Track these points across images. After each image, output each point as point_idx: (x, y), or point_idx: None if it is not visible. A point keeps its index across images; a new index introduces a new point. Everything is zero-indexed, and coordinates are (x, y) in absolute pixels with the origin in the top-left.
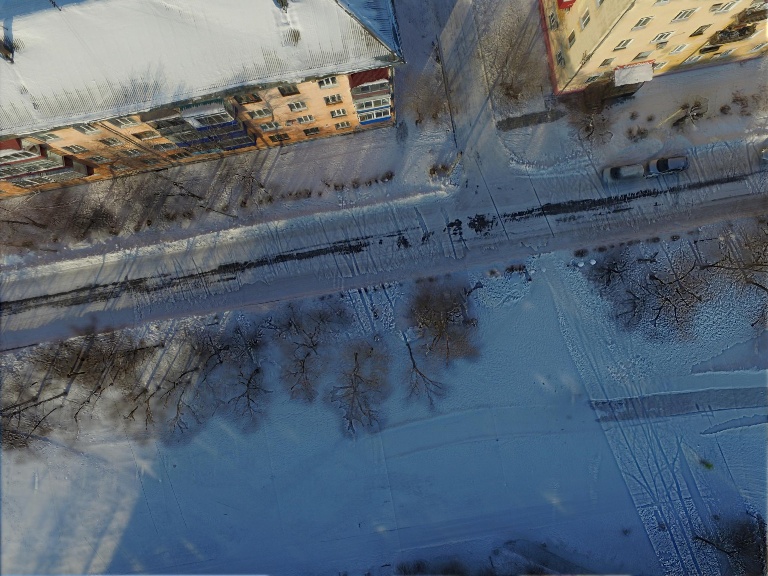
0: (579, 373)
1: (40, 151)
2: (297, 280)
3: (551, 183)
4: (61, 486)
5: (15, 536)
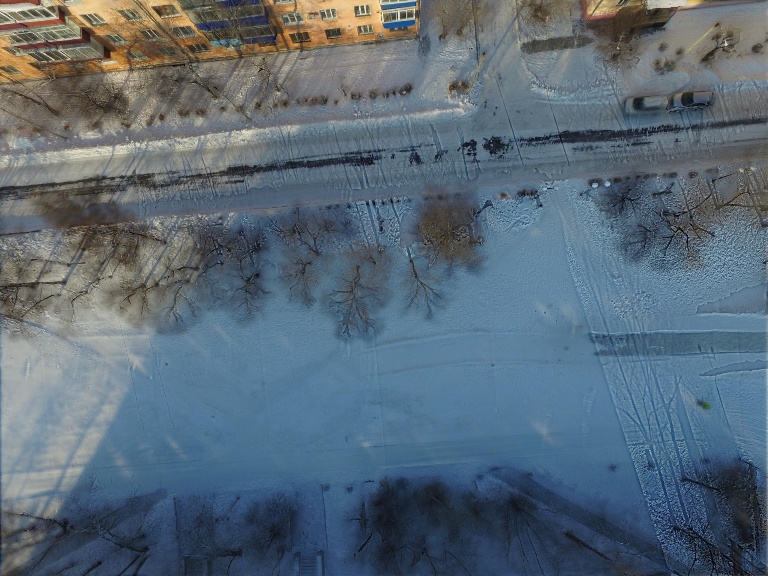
0: (582, 305)
1: (58, 12)
2: (305, 188)
3: (571, 110)
4: (52, 374)
5: (3, 420)
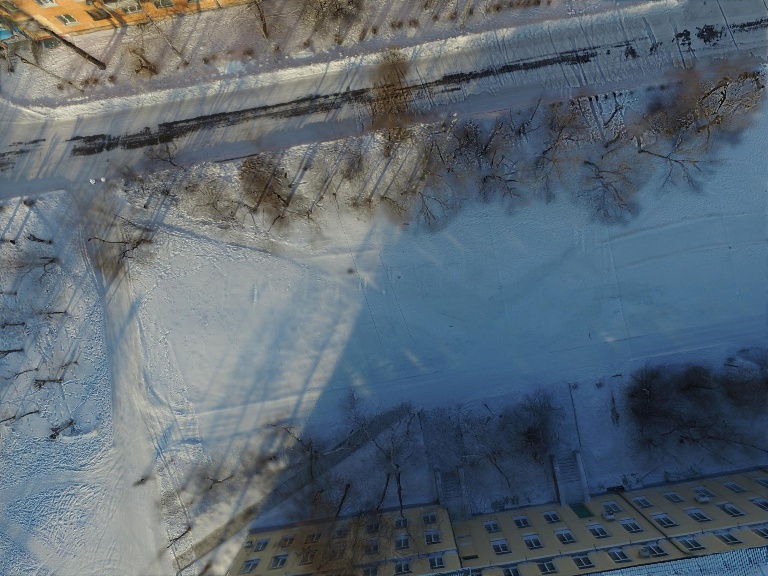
0: None
1: None
2: (523, 90)
3: None
4: (281, 298)
5: (233, 350)
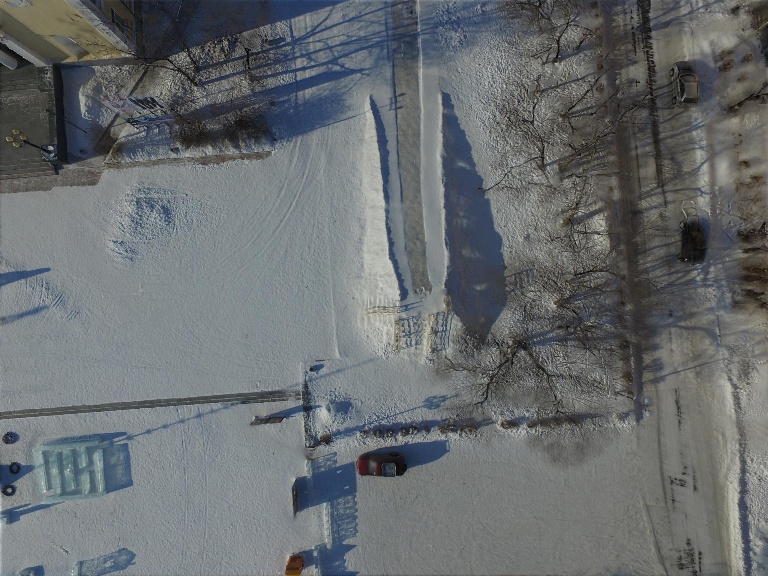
0: None
1: None
2: None
3: None
4: None
5: None
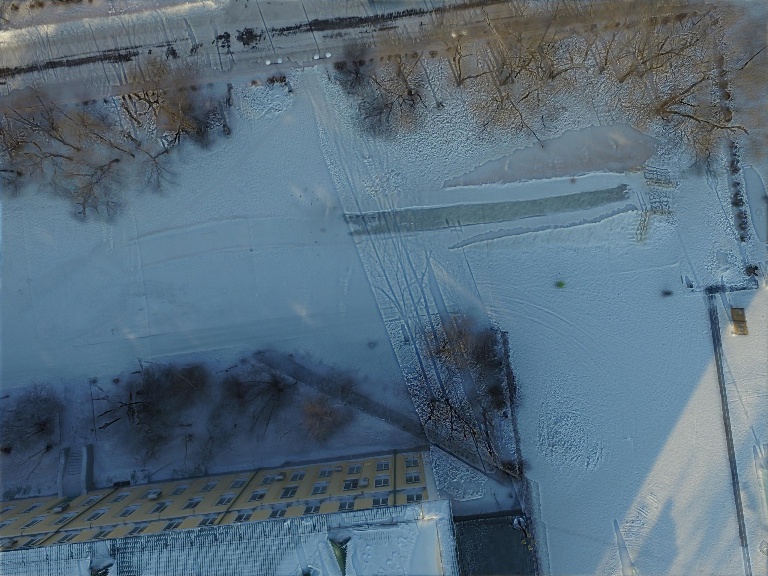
0: (335, 186)
1: None
2: (65, 87)
3: None
4: None
5: None
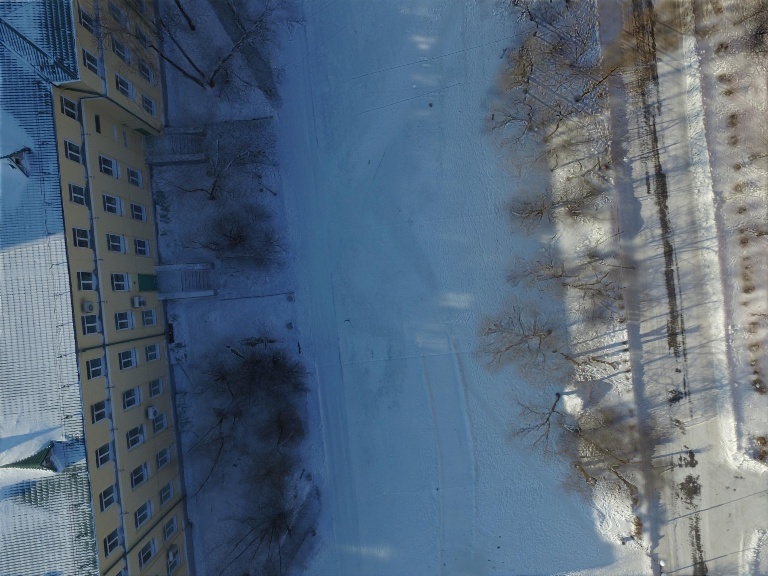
0: None
1: None
2: (641, 268)
3: (731, 575)
4: None
5: None
